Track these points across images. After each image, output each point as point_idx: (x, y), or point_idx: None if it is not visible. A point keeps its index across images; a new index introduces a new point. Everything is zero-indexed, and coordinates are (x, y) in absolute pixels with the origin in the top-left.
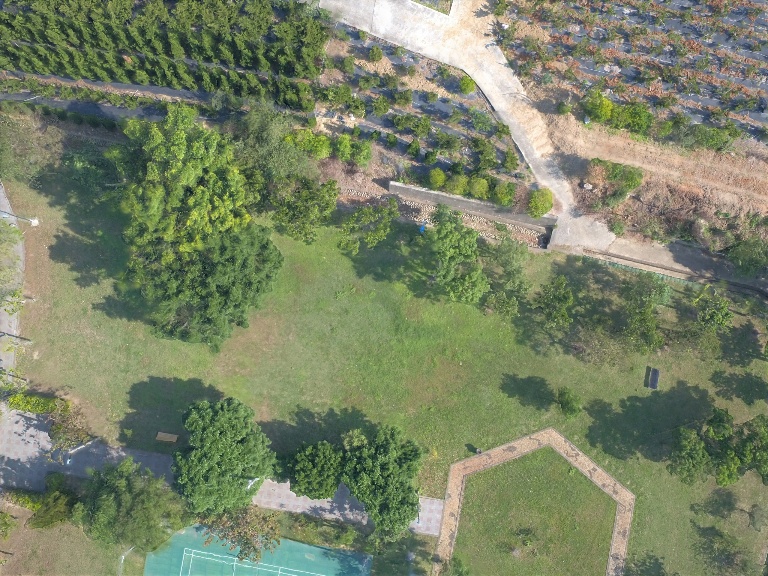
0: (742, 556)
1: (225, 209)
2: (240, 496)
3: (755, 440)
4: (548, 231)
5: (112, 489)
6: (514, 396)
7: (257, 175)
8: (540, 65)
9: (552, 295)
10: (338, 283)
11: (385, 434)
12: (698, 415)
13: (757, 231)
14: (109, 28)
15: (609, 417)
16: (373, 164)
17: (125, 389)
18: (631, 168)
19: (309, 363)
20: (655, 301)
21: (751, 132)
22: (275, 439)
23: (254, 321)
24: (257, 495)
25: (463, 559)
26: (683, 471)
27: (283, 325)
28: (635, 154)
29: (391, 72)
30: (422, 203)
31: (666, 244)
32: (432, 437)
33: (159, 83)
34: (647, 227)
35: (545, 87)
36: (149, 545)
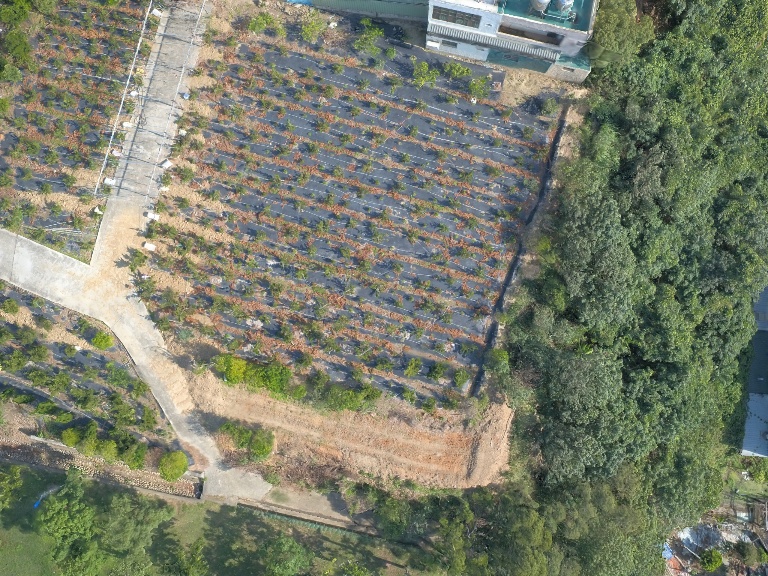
0: None
1: None
2: None
3: None
4: (201, 481)
5: None
6: None
7: None
8: (182, 318)
9: None
10: None
11: None
12: None
13: (403, 490)
14: None
15: None
16: (15, 416)
17: None
18: (259, 436)
19: None
20: (281, 575)
21: (394, 390)
22: None
23: None
24: None
25: None
26: None
27: None
28: (275, 413)
29: (31, 323)
30: (72, 451)
31: (324, 493)
32: None
33: None
34: (299, 479)
35: (185, 341)
36: None
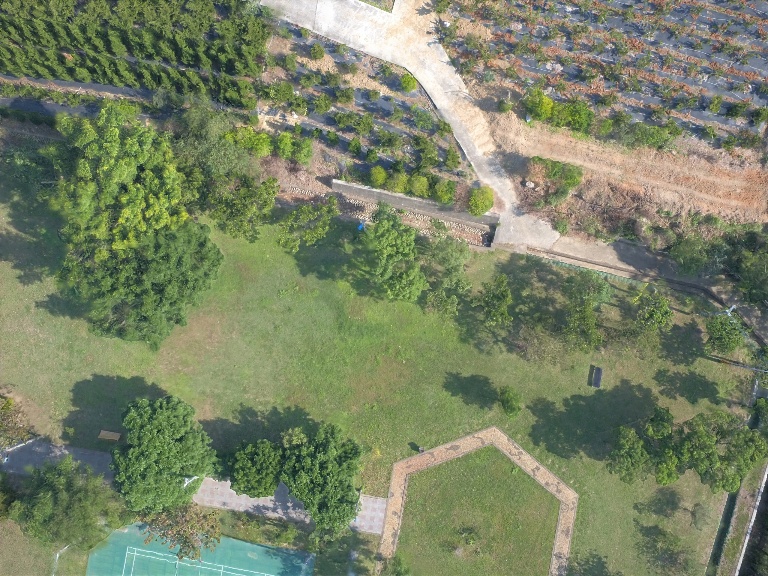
0: (685, 555)
1: (160, 207)
2: (179, 494)
3: (693, 439)
4: (492, 229)
5: (50, 487)
6: (457, 395)
7: (196, 173)
8: (482, 63)
9: (492, 293)
10: (281, 281)
11: (326, 432)
12: (642, 414)
13: (699, 229)
14: (51, 25)
15: (552, 416)
16: (316, 162)
17: (68, 387)
18: (571, 166)
19: (252, 361)
20: (594, 299)
21: (693, 130)
22: (218, 437)
23: (197, 319)
24: (200, 493)
25: (406, 558)
26: (622, 470)
27: (226, 323)
28: (576, 152)
29: (333, 70)
30: (366, 201)
31: (610, 242)
32: (375, 436)
33: (101, 81)
34: (590, 225)
35: (487, 85)
36: (85, 543)
